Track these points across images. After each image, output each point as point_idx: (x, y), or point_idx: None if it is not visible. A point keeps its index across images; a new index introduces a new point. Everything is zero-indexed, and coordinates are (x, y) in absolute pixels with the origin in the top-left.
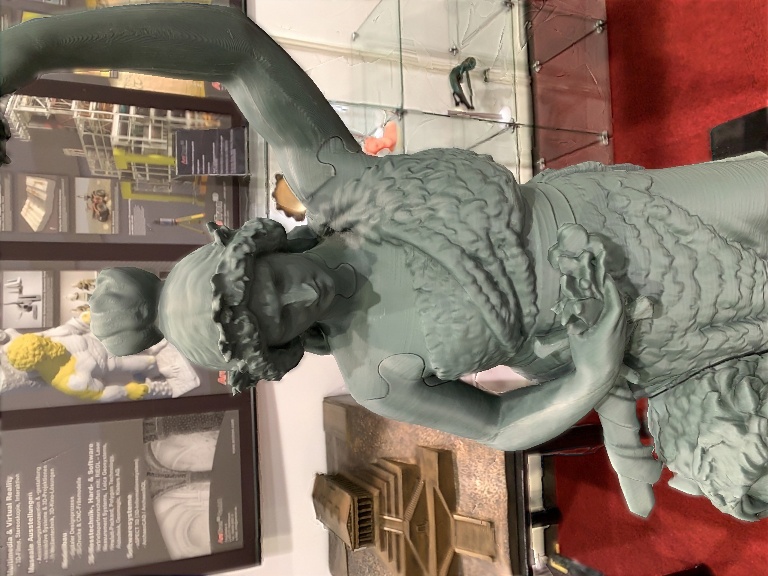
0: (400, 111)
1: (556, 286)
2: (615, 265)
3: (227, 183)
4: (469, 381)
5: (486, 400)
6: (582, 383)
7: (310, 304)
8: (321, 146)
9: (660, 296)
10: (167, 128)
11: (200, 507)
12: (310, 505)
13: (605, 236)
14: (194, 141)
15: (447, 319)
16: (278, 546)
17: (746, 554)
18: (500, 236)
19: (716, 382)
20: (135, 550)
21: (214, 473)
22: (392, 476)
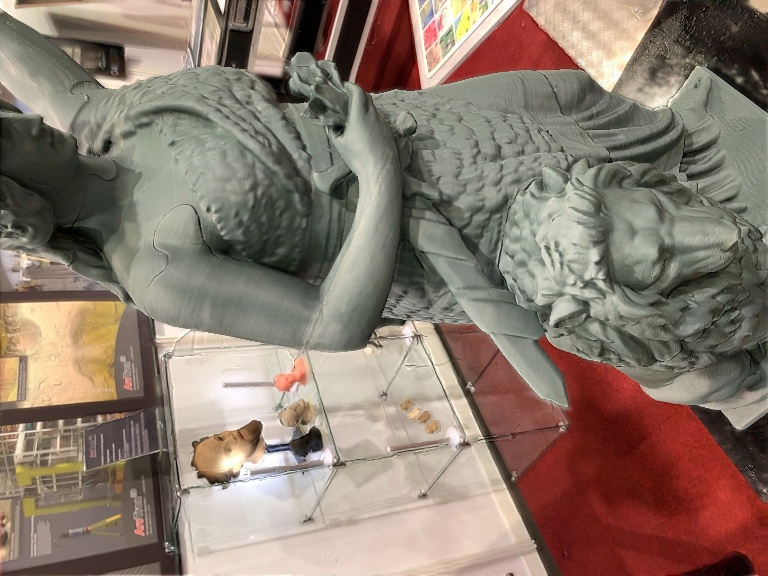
0: None
1: (323, 138)
2: None
3: (146, 476)
4: None
5: (300, 279)
6: (365, 182)
7: (36, 130)
8: (74, 85)
9: (432, 135)
10: (77, 435)
11: None
12: None
13: None
14: (103, 433)
15: (201, 150)
16: None
17: None
18: (244, 92)
19: None
20: None
21: None
22: None
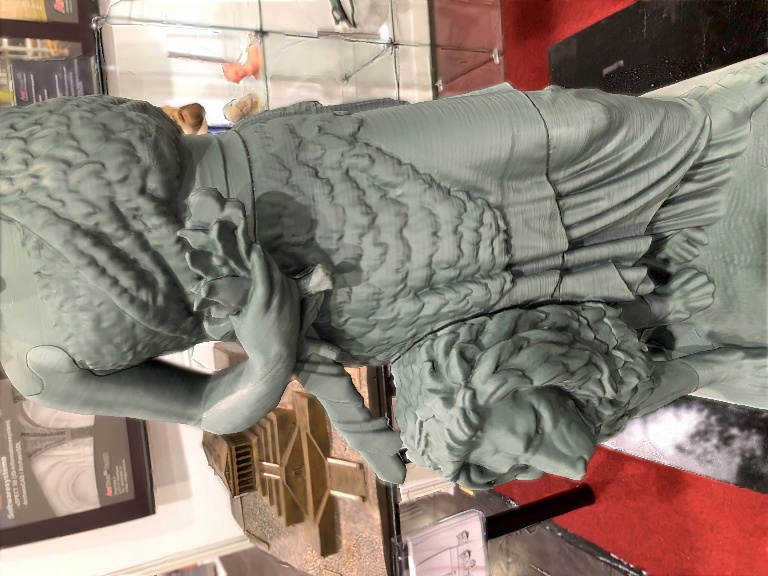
0: (259, 34)
1: None
2: (298, 229)
3: None
4: (178, 360)
5: (184, 383)
6: (253, 367)
7: None
8: None
9: (359, 260)
10: (5, 60)
11: (84, 463)
12: (201, 452)
13: (286, 195)
14: (33, 74)
15: (71, 307)
16: (177, 493)
17: (618, 473)
18: (130, 205)
19: (434, 350)
20: (16, 510)
21: (97, 428)
22: (268, 423)
